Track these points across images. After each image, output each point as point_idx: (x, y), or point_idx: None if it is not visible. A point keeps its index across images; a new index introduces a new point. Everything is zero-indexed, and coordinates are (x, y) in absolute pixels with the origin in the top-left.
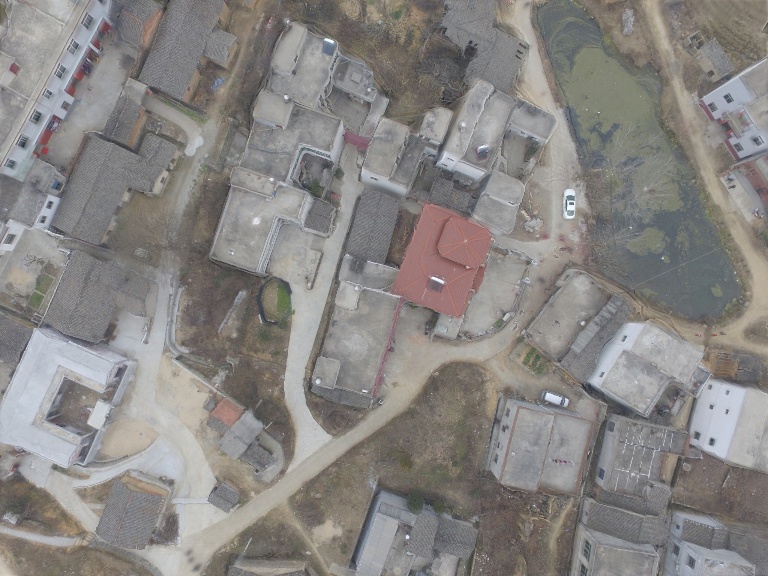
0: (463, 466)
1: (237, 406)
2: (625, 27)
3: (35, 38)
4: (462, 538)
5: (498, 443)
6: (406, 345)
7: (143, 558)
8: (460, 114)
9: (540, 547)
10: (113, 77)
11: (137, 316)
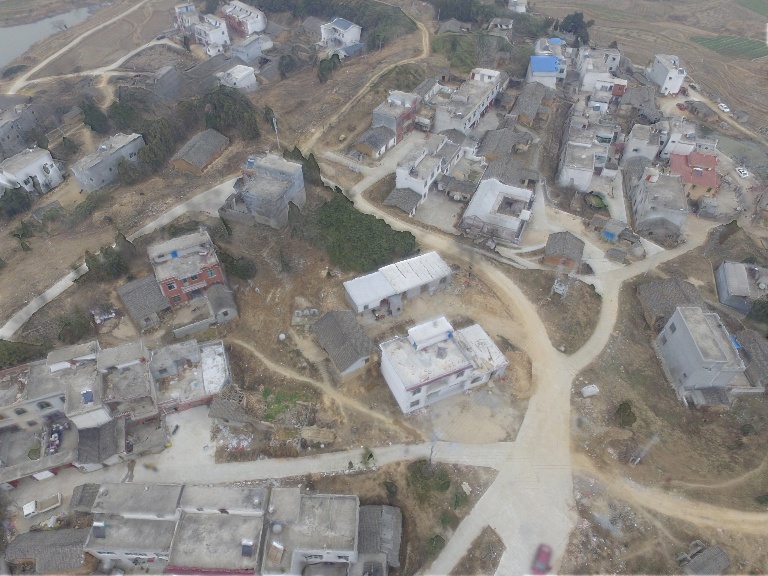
0: (763, 259)
1: None
2: (723, 127)
3: (475, 93)
4: None
5: None
6: None
7: None
8: (673, 122)
9: None
10: (494, 118)
11: None
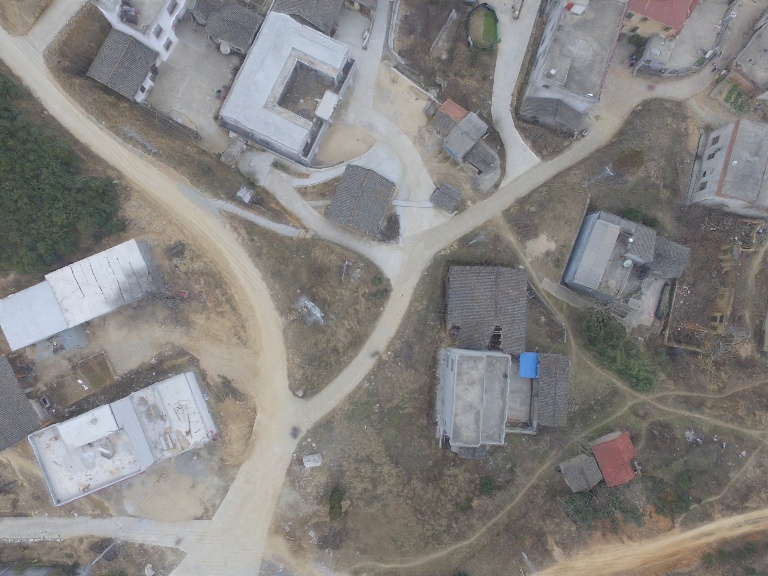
0: (671, 191)
1: (461, 107)
2: None
3: None
4: (676, 254)
5: (703, 173)
6: (610, 79)
7: (364, 255)
8: None
9: (738, 283)
10: None
11: (356, 22)
